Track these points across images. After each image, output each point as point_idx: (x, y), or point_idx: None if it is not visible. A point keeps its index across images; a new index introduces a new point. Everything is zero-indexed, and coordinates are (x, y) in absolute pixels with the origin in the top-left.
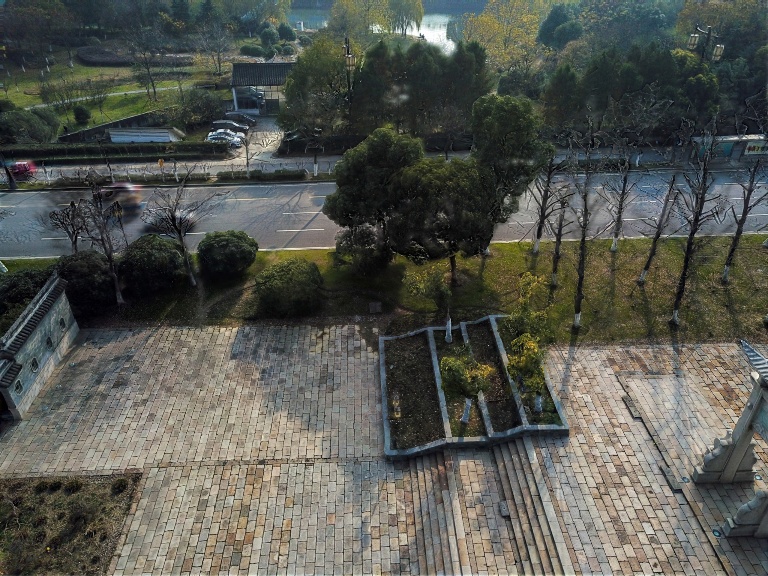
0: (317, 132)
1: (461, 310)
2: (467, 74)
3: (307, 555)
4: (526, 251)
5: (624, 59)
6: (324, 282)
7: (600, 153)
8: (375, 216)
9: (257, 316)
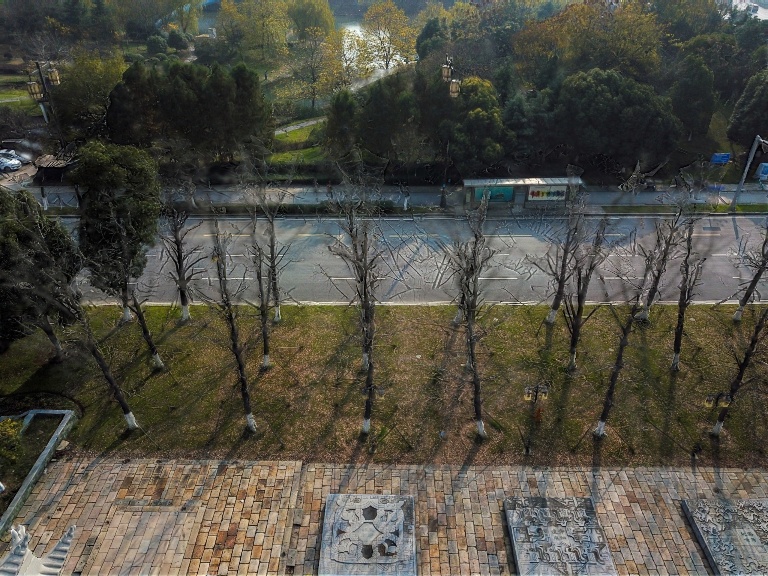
0: None
1: (28, 397)
2: (223, 101)
3: None
4: (176, 318)
5: (411, 87)
6: None
7: (378, 192)
8: None
9: None
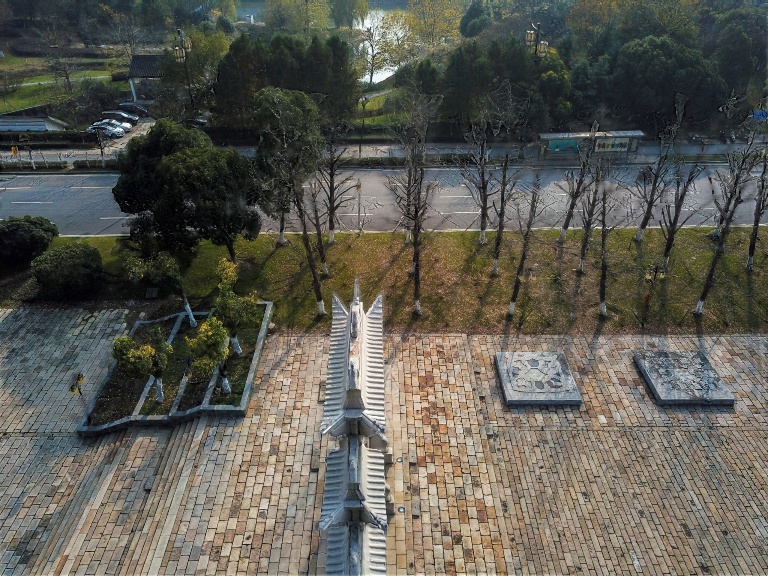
0: (199, 123)
1: None
2: (323, 68)
3: None
4: None
5: (485, 55)
6: (111, 267)
7: (459, 148)
8: (152, 204)
9: (35, 298)
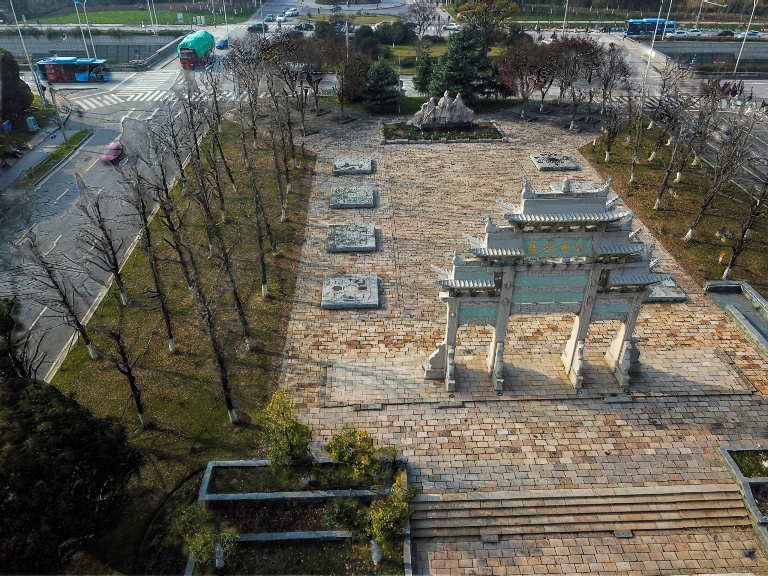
0: None
1: (153, 541)
2: None
3: None
4: None
5: None
6: None
7: None
8: None
9: None
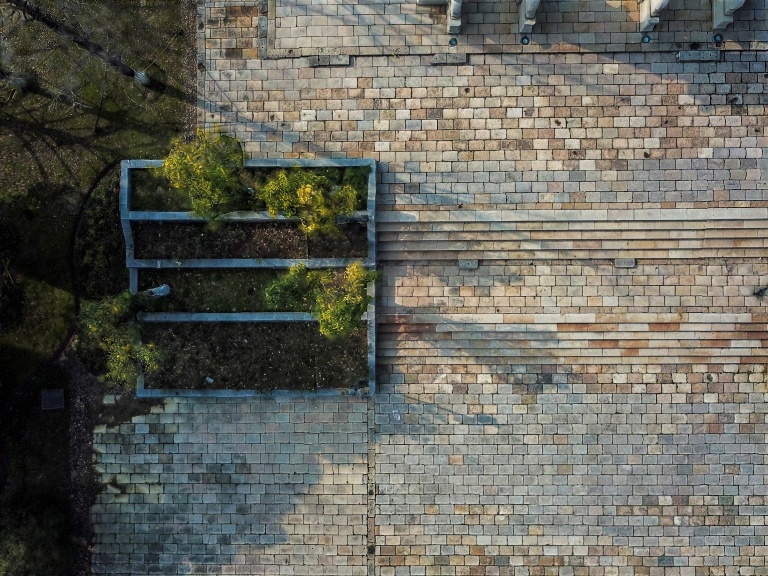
0: None
1: (84, 258)
2: None
3: (500, 484)
4: None
5: None
6: None
7: None
8: None
9: None
